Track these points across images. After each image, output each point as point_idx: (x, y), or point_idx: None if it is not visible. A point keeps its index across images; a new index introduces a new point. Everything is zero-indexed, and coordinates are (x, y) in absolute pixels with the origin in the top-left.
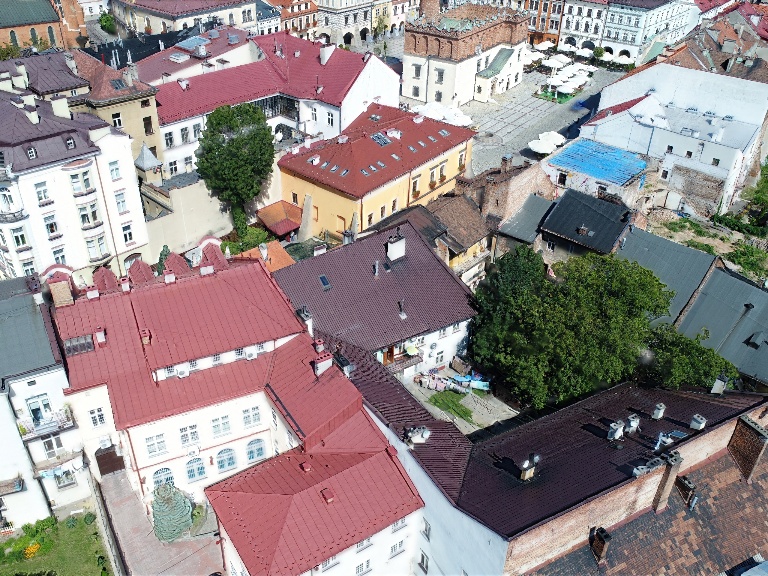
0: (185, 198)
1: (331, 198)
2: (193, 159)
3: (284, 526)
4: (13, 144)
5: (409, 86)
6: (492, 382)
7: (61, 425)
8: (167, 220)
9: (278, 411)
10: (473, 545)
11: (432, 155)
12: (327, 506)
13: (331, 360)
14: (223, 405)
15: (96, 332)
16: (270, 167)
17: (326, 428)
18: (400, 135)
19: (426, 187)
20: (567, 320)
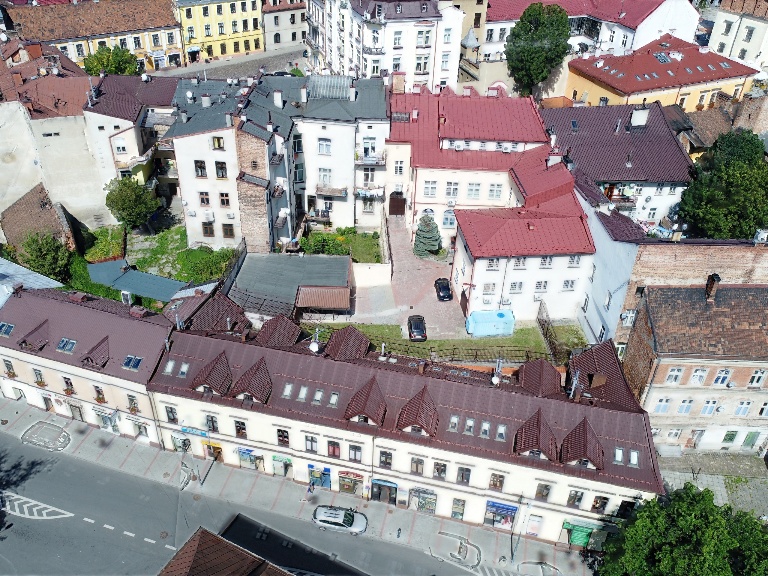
0: (490, 71)
1: (604, 94)
2: (503, 56)
3: (498, 231)
4: (390, 0)
5: (716, 42)
6: (689, 236)
7: (378, 162)
8: (473, 85)
9: (514, 185)
10: (618, 263)
11: (706, 79)
12: (529, 231)
13: (560, 157)
14: (479, 174)
15: (413, 110)
16: (561, 59)
17: (543, 196)
18: (681, 57)
19: (693, 108)
20: (762, 181)
